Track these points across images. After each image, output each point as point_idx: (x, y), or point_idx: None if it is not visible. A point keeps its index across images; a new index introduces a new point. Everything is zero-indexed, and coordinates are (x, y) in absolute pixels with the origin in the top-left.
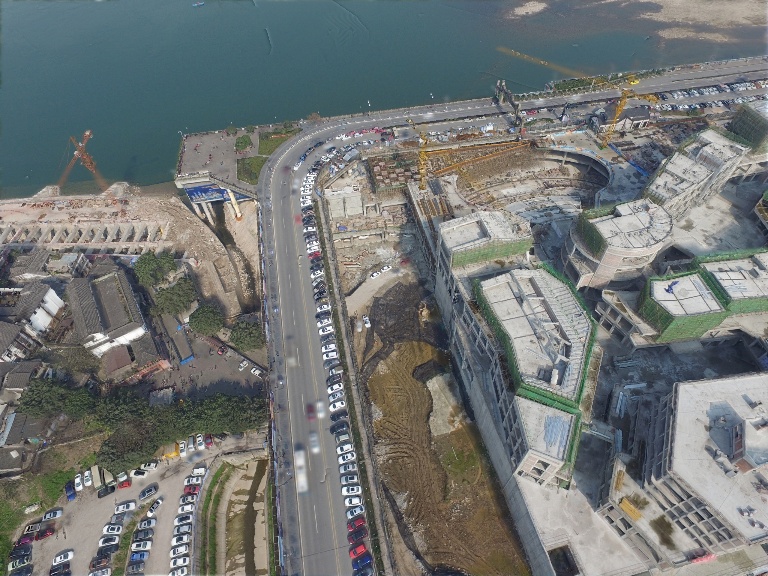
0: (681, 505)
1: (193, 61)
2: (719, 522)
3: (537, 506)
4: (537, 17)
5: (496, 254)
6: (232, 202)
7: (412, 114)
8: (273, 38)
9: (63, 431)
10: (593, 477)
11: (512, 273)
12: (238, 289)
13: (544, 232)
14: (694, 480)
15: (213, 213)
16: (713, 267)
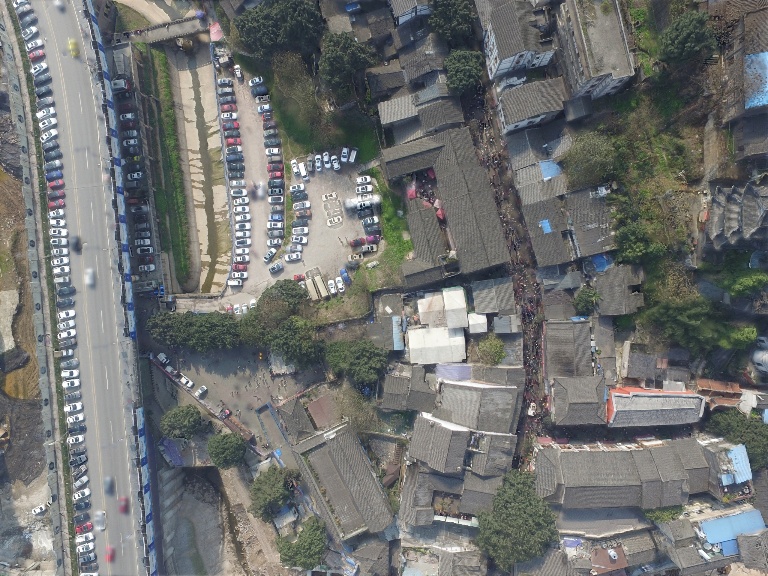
0: None
1: None
2: None
3: None
4: None
5: None
6: None
7: None
8: None
9: (363, 334)
10: None
11: None
12: None
13: None
14: None
15: None
16: None
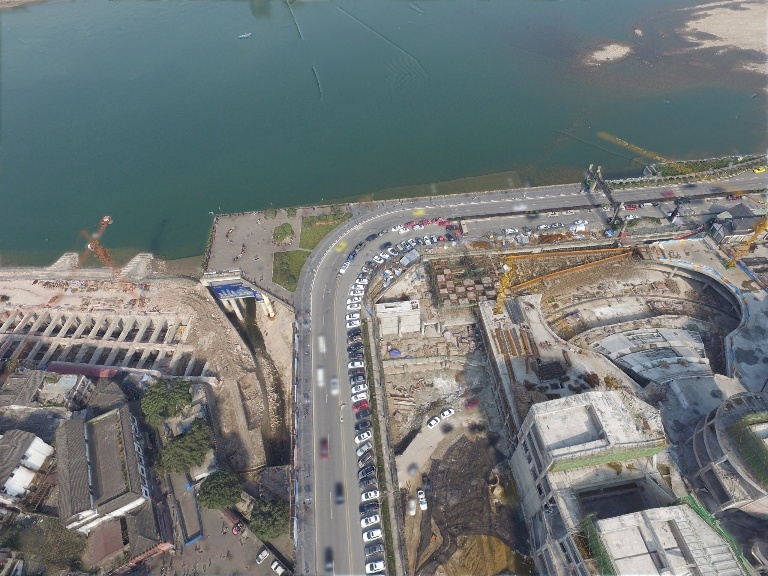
0: None
1: (235, 110)
2: None
3: None
4: (619, 64)
5: (612, 460)
6: (265, 302)
7: (483, 201)
8: (324, 86)
9: None
10: None
11: (646, 516)
12: (264, 421)
13: (662, 397)
14: None
15: (243, 304)
16: None
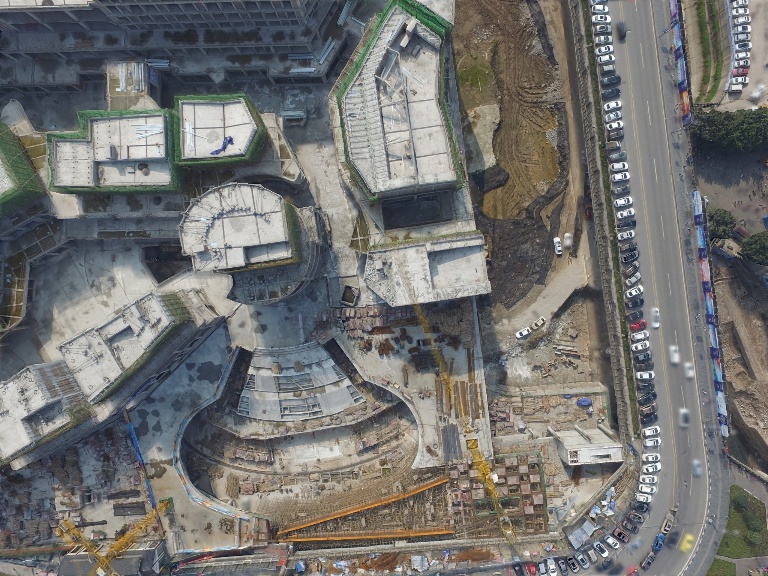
0: None
1: None
2: None
3: None
4: None
5: None
6: None
7: None
8: None
9: None
10: (373, 3)
11: None
12: None
13: (320, 325)
14: None
15: None
16: (154, 177)
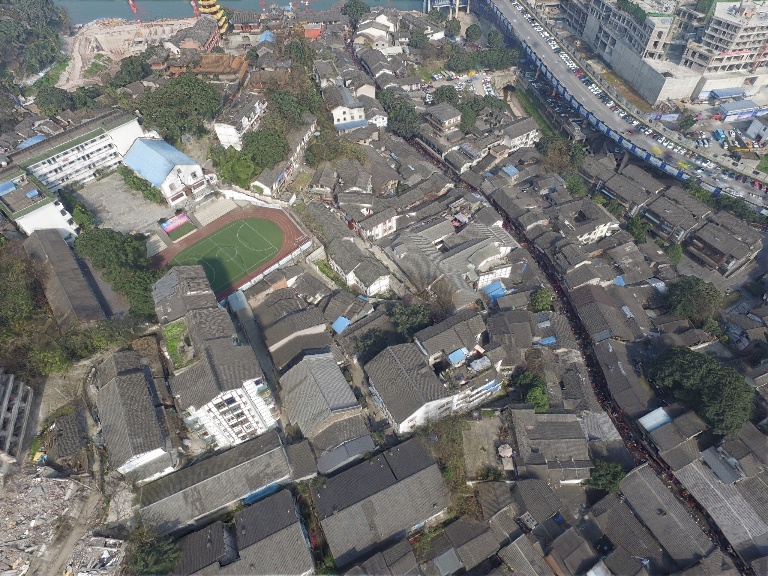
0: (717, 35)
1: None
2: (732, 28)
3: (654, 64)
4: None
5: None
6: (456, 6)
7: None
8: None
9: None
10: (677, 59)
11: None
12: None
13: None
14: (723, 17)
15: None
16: None
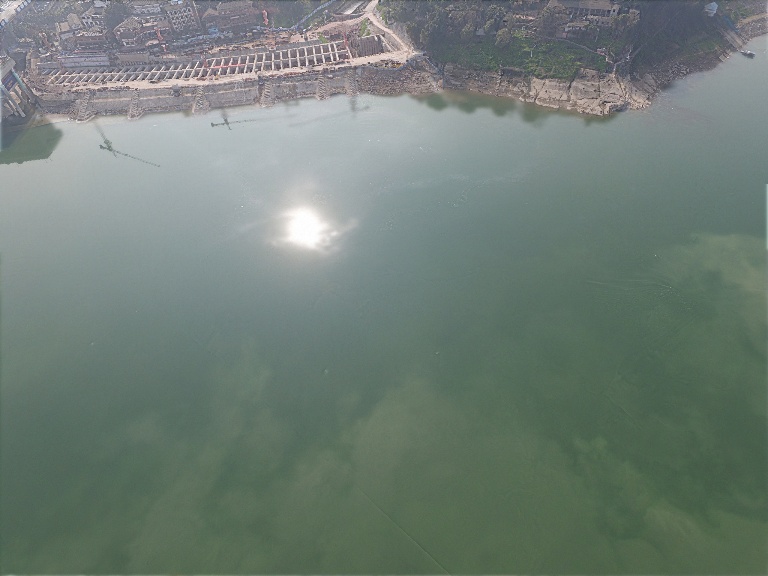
0: None
1: None
2: None
3: None
4: None
5: None
6: None
7: None
8: None
9: None
10: None
11: None
12: None
13: None
14: None
15: None
16: None
